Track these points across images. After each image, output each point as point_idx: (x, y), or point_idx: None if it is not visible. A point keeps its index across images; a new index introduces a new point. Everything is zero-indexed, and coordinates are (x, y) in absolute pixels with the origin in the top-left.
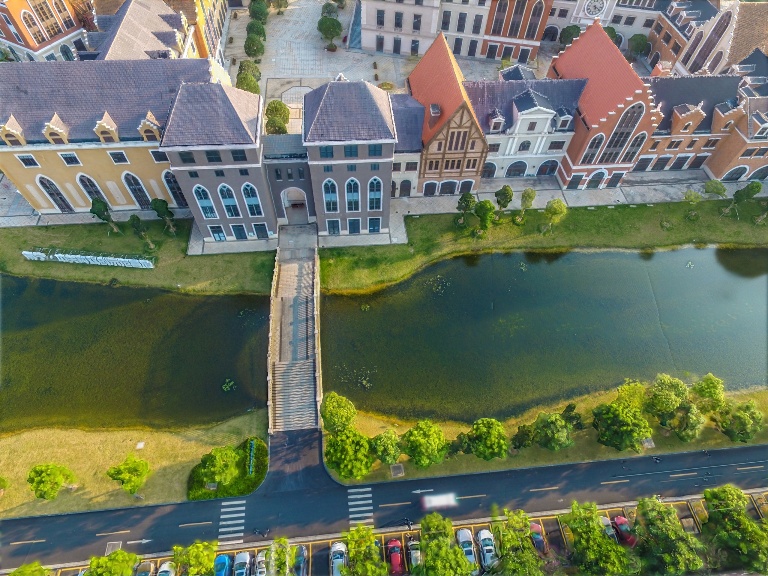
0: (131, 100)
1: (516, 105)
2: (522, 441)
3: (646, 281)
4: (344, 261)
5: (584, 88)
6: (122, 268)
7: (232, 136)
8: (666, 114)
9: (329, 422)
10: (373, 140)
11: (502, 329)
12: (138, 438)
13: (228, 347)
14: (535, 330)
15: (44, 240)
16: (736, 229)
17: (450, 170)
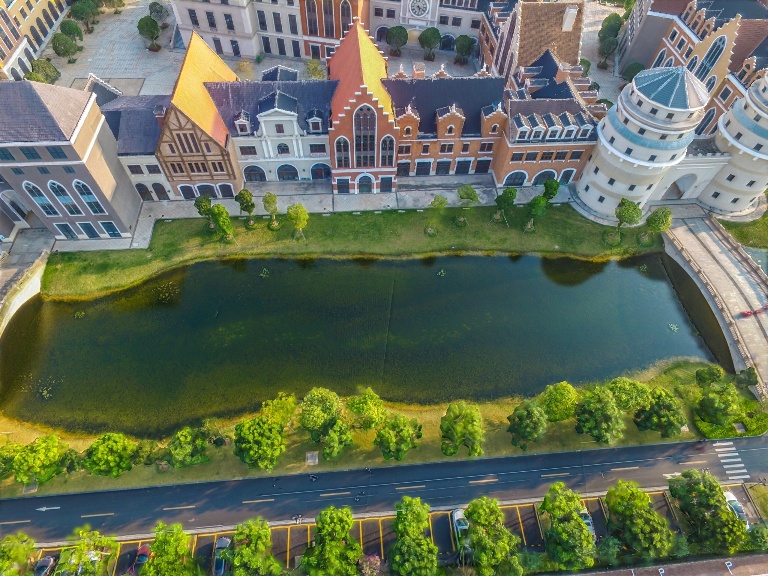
0: None
1: (259, 107)
2: (134, 458)
3: (389, 289)
4: (72, 266)
5: (336, 90)
6: None
7: None
8: (429, 117)
9: None
10: (45, 142)
11: (218, 338)
12: None
13: None
14: (252, 339)
15: None
16: (503, 236)
17: (198, 173)
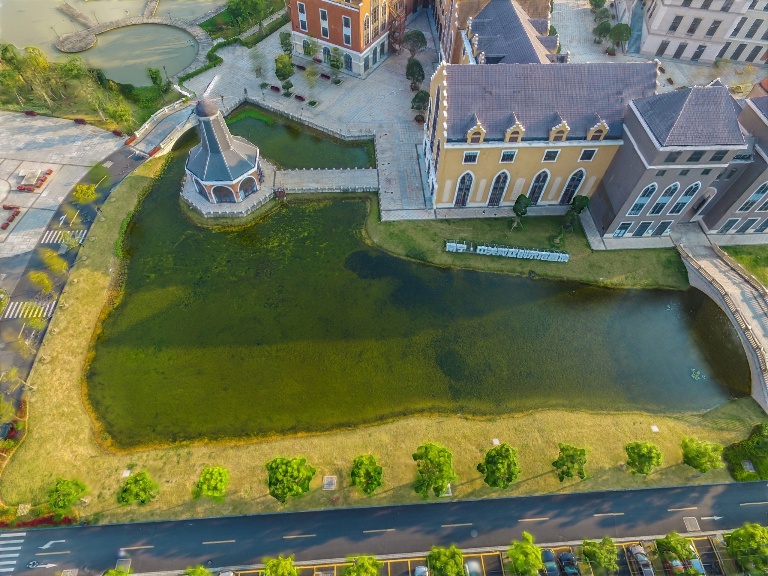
0: (581, 101)
1: None
2: None
3: None
4: (744, 259)
5: None
6: (537, 261)
7: (727, 137)
8: None
9: None
10: None
11: None
12: (646, 422)
13: (674, 338)
14: None
15: (452, 233)
16: None
17: None
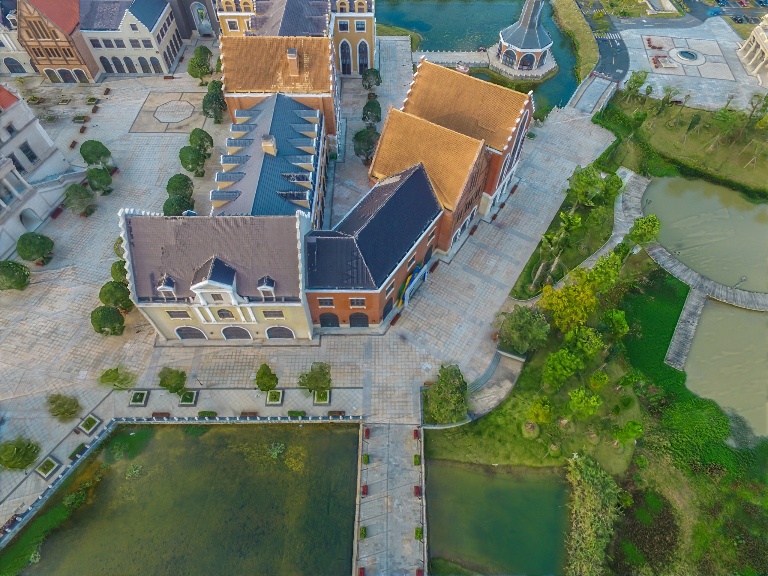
0: None
1: None
2: None
3: None
4: None
5: None
6: None
7: None
8: None
9: None
10: None
11: None
12: None
13: None
14: None
15: None
16: None
17: None
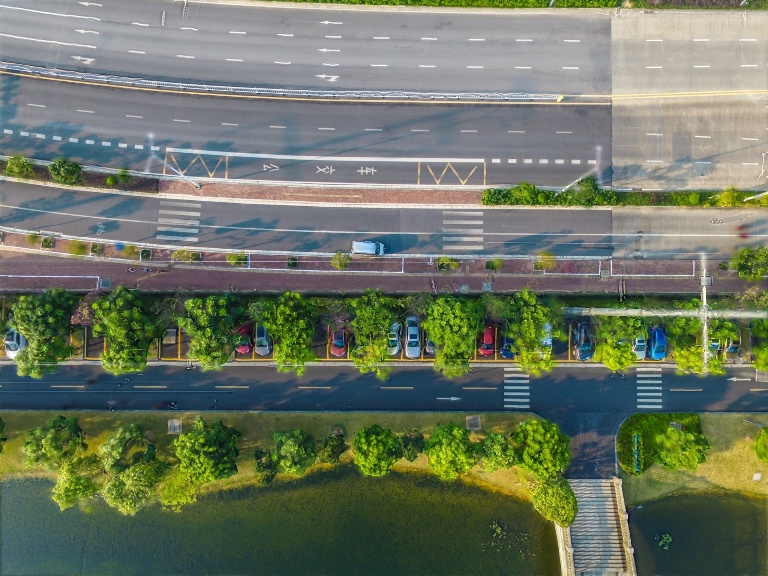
0: None
1: None
2: (340, 445)
3: None
4: None
5: None
6: None
7: None
8: None
9: (568, 489)
10: None
11: None
12: (760, 485)
13: None
14: None
15: None
16: None
17: None
